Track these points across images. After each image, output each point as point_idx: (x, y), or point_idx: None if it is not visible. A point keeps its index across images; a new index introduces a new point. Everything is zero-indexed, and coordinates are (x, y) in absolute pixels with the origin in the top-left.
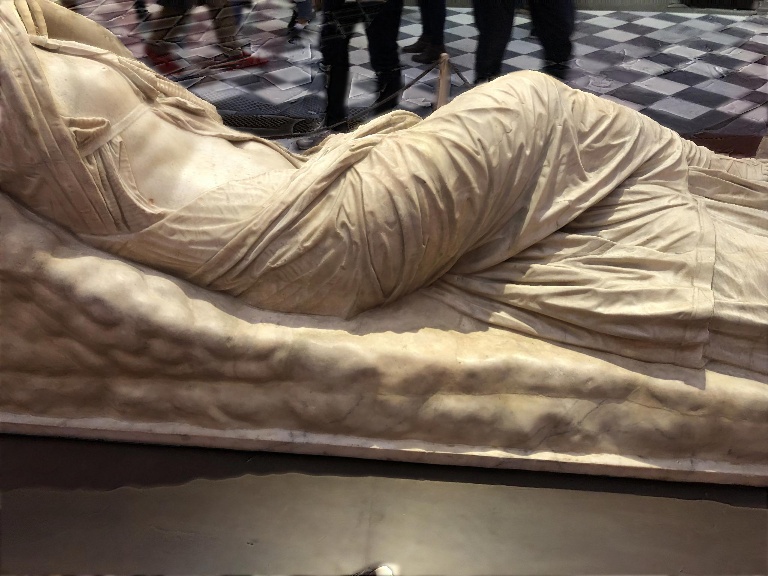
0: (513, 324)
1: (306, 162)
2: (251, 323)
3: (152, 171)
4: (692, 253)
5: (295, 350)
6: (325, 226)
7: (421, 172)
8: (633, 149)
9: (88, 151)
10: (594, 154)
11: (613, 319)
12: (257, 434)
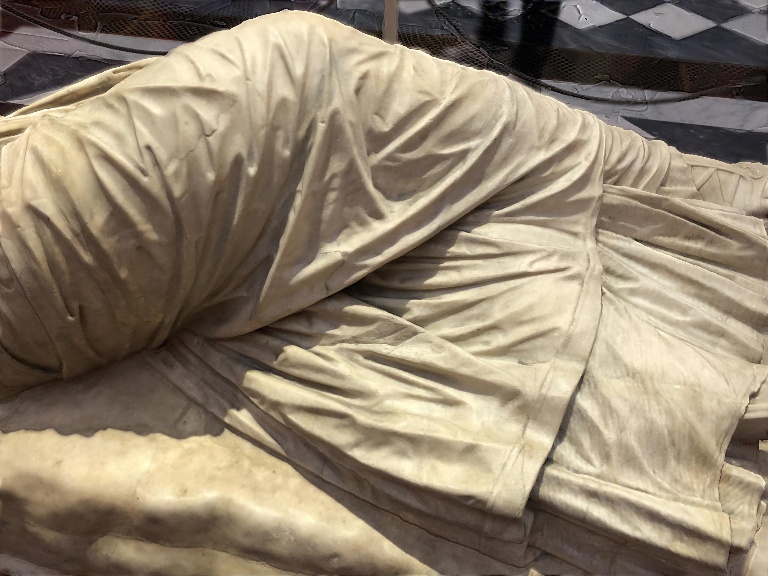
0: (253, 434)
1: None
2: None
3: None
4: (543, 368)
5: None
6: None
7: (43, 200)
8: (483, 163)
9: None
10: (404, 170)
11: None
12: None
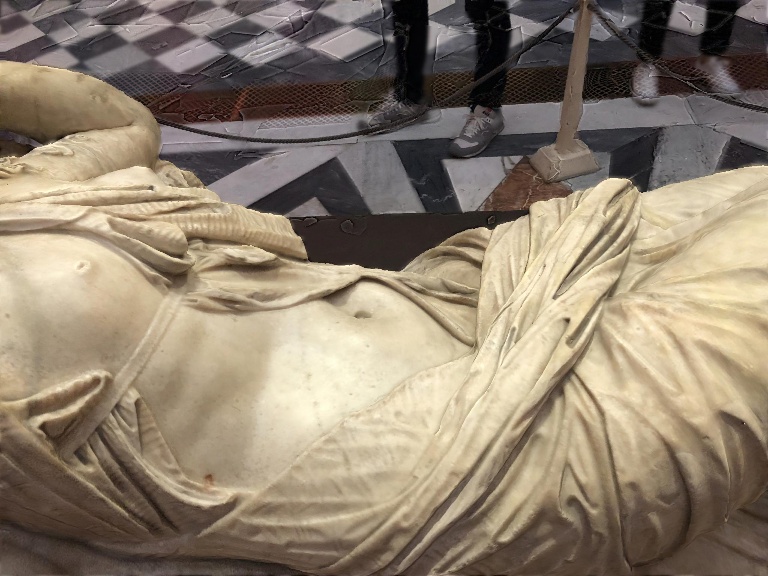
0: None
1: None
2: None
3: (203, 426)
4: None
5: None
6: (538, 507)
7: (734, 403)
8: None
9: (77, 440)
10: None
11: None
12: None
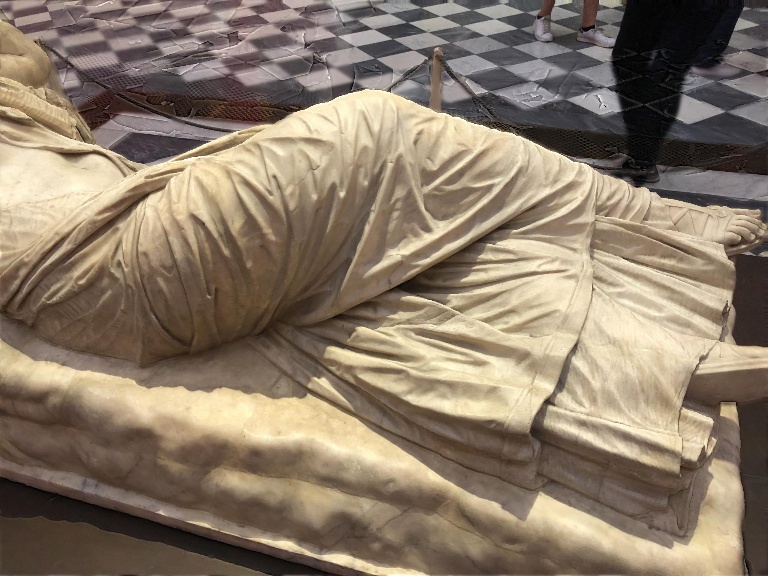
0: (329, 395)
1: (110, 186)
2: (34, 360)
3: None
4: (547, 339)
5: (69, 397)
6: (99, 264)
7: (201, 211)
8: (504, 194)
9: None
10: (447, 198)
11: (424, 412)
12: (51, 475)
